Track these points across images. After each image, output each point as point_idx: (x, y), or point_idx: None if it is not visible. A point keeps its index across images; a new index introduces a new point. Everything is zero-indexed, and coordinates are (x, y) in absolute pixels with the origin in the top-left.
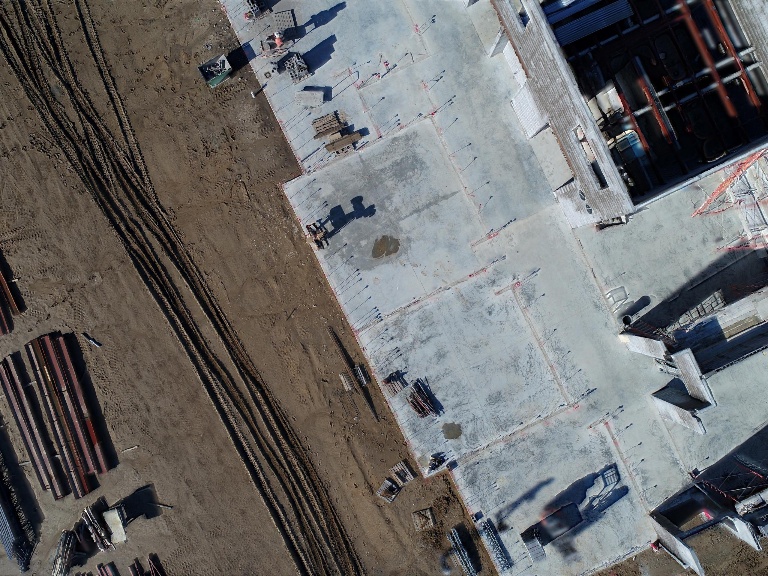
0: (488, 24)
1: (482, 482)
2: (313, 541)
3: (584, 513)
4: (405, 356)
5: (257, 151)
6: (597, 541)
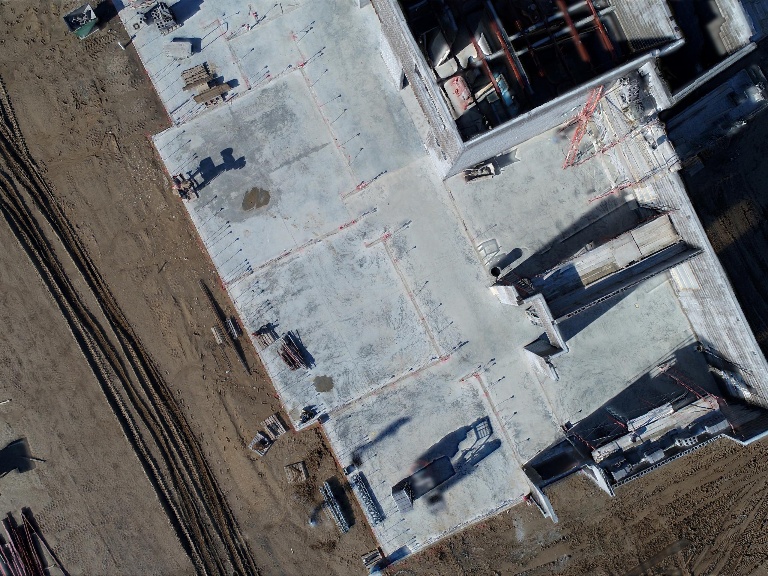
0: None
1: (354, 435)
2: (186, 495)
3: (456, 466)
4: (276, 309)
5: (127, 103)
6: (470, 494)
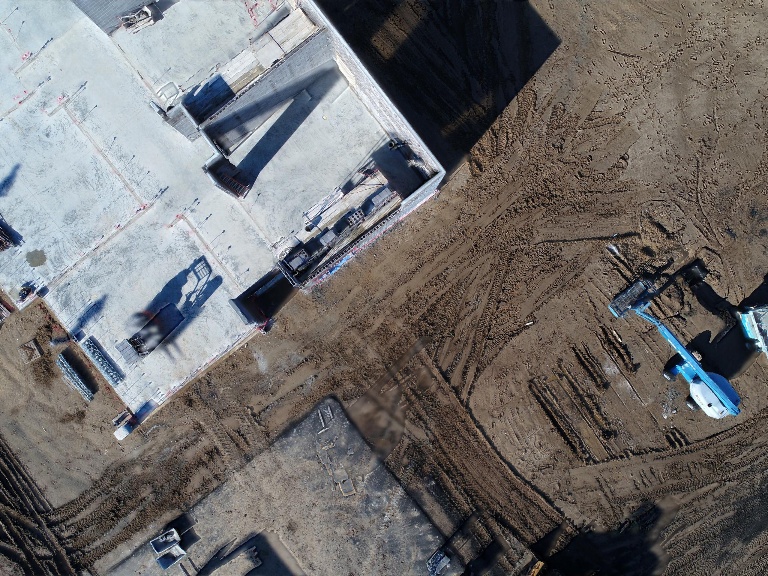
0: None
1: (77, 302)
2: None
3: (184, 311)
4: None
5: None
6: (203, 336)
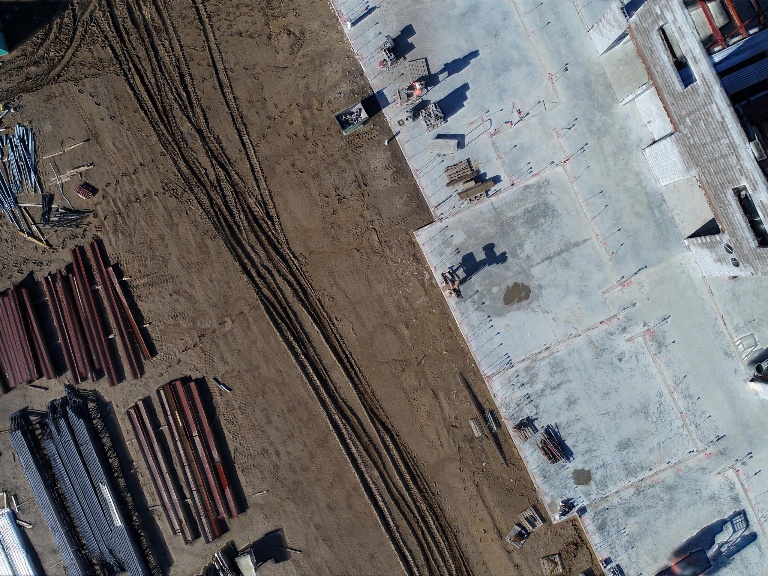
0: (620, 72)
1: (611, 528)
2: None
3: (713, 559)
4: (535, 402)
5: (389, 198)
6: None
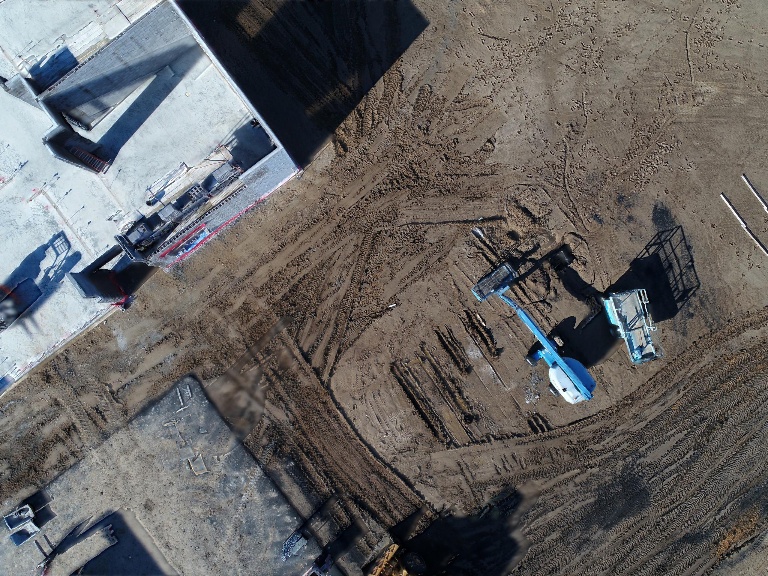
0: None
1: None
2: None
3: (42, 286)
4: None
5: None
6: (60, 311)
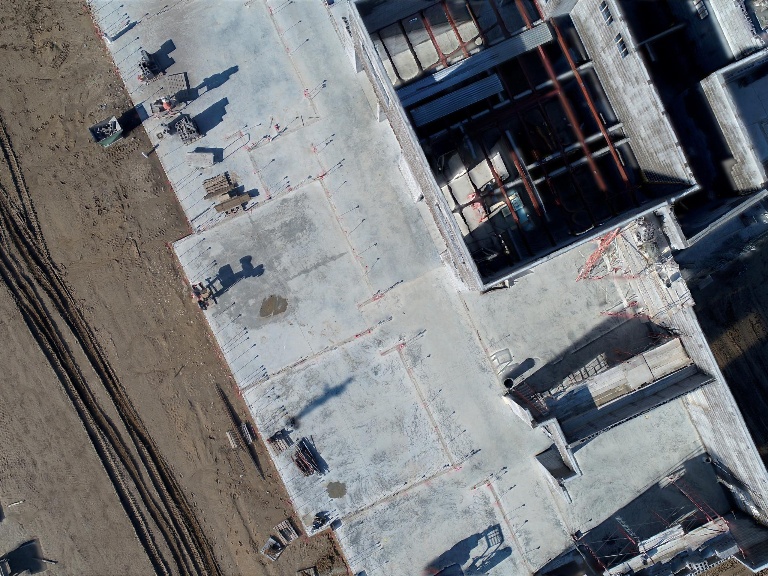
0: None
1: (366, 542)
2: None
3: (467, 574)
4: (291, 415)
5: (149, 210)
6: None
